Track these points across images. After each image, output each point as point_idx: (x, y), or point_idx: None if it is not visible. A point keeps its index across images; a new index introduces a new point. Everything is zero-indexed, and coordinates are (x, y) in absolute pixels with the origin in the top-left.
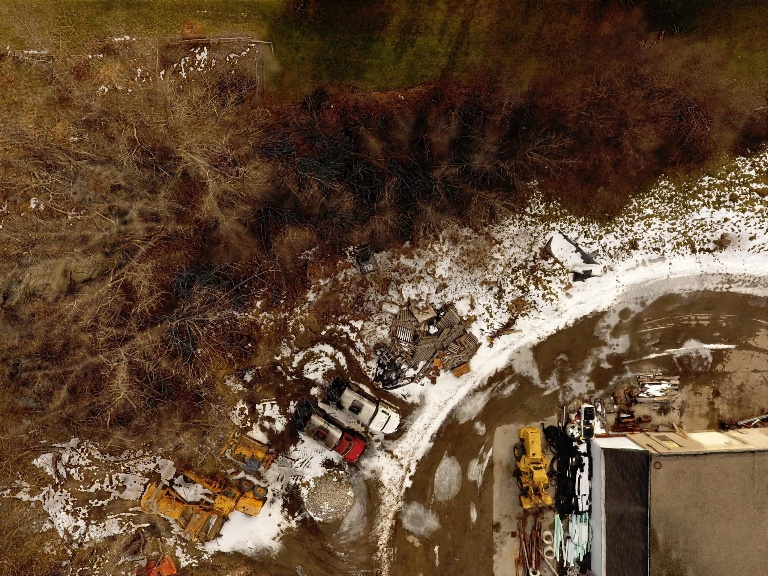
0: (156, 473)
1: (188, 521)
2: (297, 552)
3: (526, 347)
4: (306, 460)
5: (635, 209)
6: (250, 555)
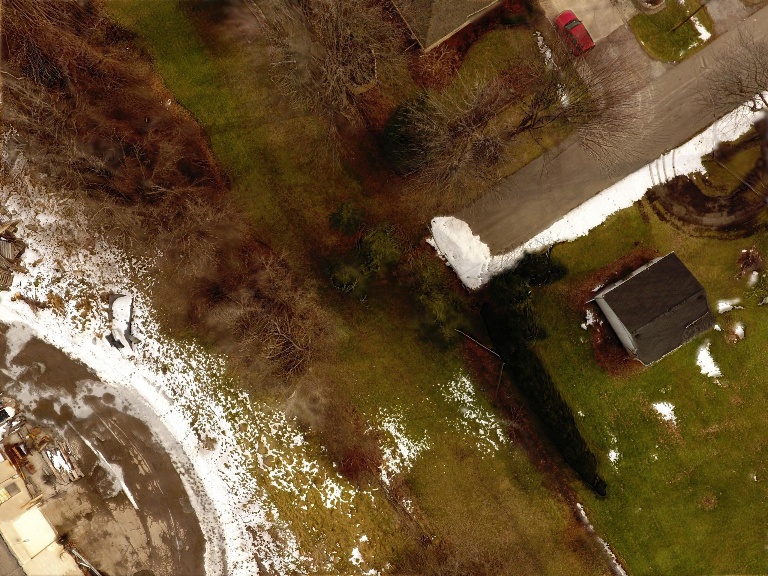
0: None
1: None
2: None
3: (32, 331)
4: None
5: (188, 351)
6: None
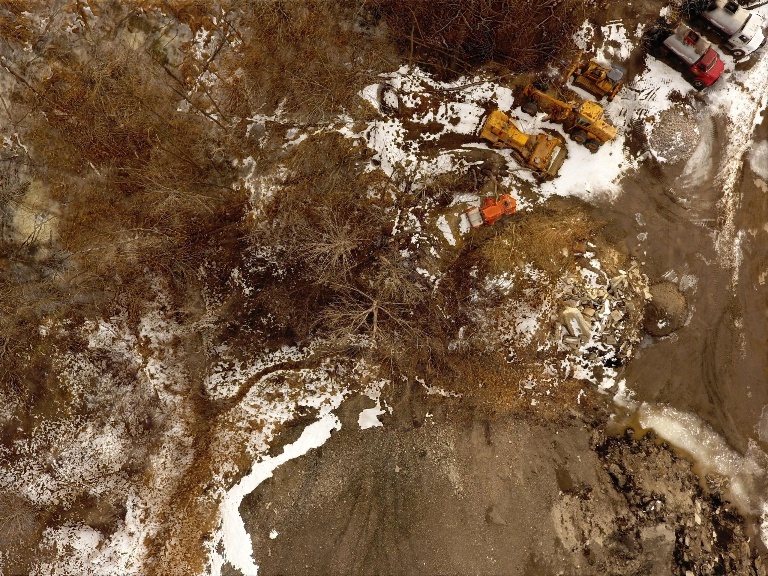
0: (493, 103)
1: (532, 151)
2: (637, 197)
3: None
4: (652, 91)
5: None
6: (587, 200)
